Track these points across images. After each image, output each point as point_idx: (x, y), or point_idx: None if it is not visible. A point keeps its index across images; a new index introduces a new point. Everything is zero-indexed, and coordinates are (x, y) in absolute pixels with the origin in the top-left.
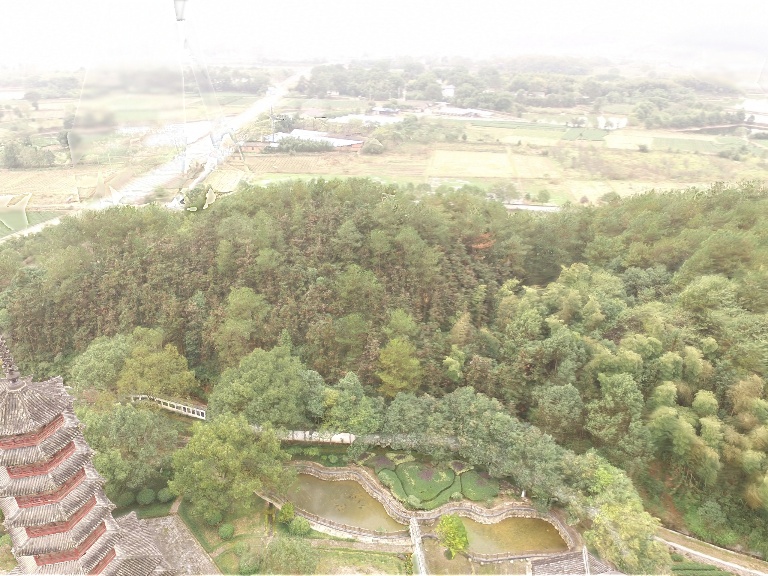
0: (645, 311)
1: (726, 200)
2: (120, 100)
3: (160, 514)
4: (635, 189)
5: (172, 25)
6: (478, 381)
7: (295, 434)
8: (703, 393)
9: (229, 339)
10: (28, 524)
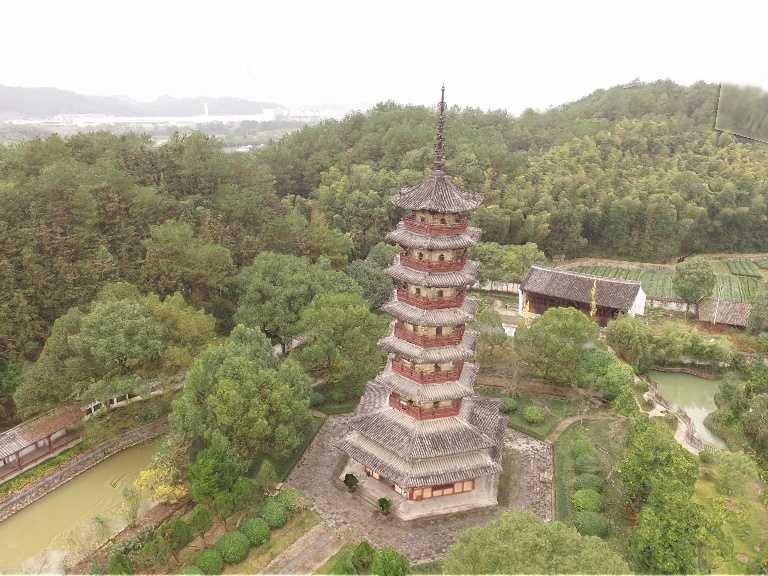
0: (405, 175)
1: (363, 119)
2: None
3: (322, 422)
4: (277, 134)
5: None
6: None
7: (292, 341)
8: None
9: (203, 269)
10: None
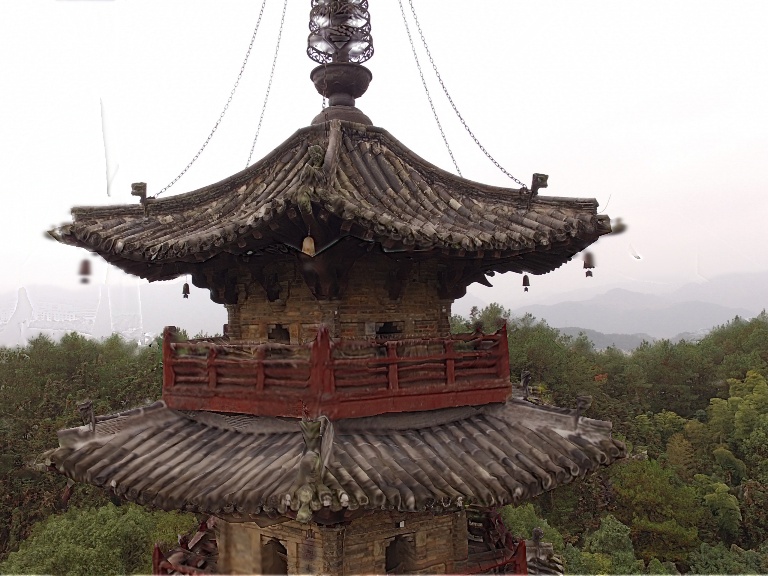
0: None
1: None
2: (7, 274)
3: None
4: (695, 333)
5: (100, 191)
6: (765, 527)
7: None
8: None
9: None
10: None
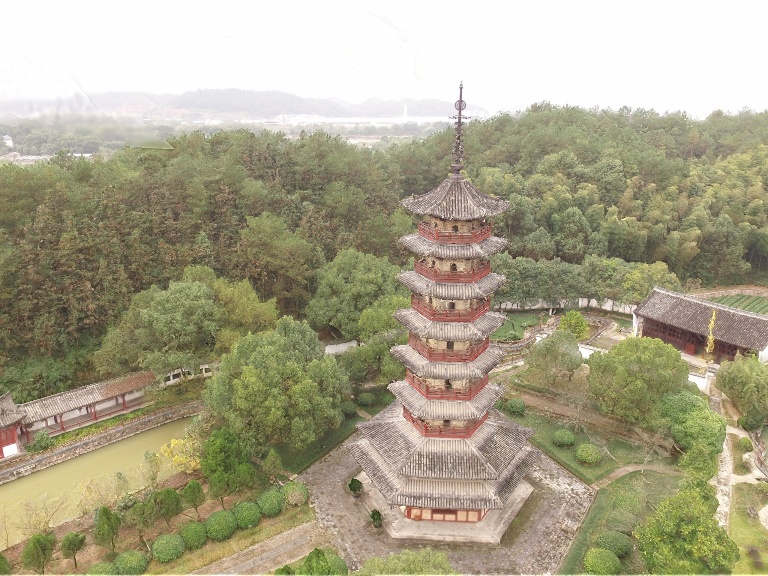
0: (536, 180)
1: (507, 121)
2: None
3: None
4: (422, 134)
5: None
6: None
7: None
8: (611, 207)
9: (286, 261)
10: (489, 332)
